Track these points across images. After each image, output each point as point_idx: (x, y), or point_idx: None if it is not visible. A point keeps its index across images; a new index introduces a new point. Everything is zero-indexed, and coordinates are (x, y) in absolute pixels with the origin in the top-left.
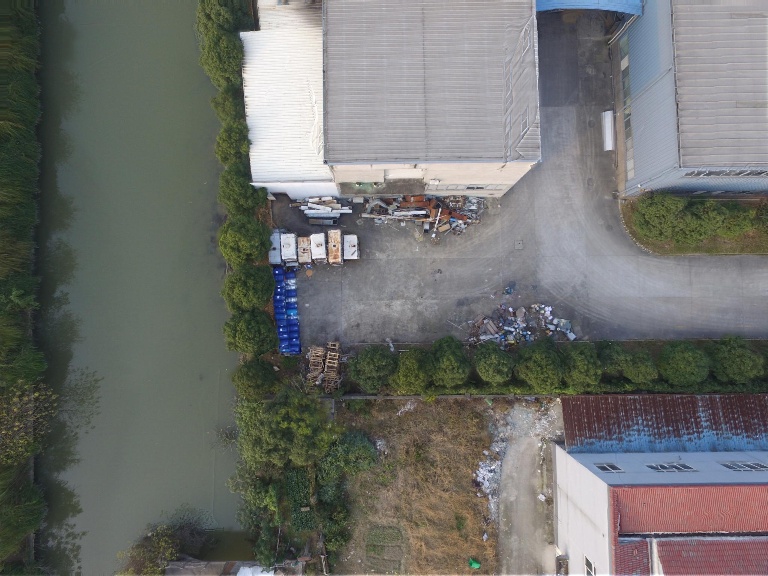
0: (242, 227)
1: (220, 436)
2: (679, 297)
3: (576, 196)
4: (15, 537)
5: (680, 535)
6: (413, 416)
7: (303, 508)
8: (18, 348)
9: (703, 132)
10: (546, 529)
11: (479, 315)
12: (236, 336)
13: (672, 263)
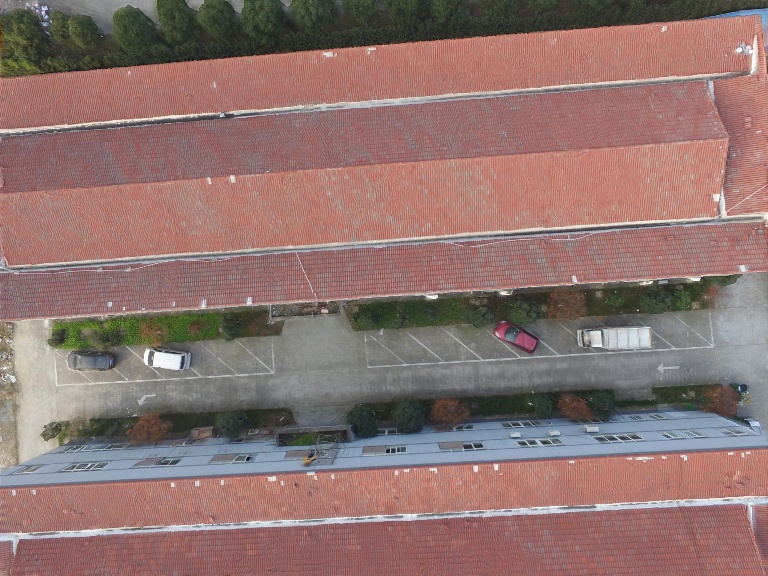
0: None
1: None
2: None
3: None
4: None
5: (29, 133)
6: None
7: None
8: None
9: None
10: None
11: None
12: None
13: None
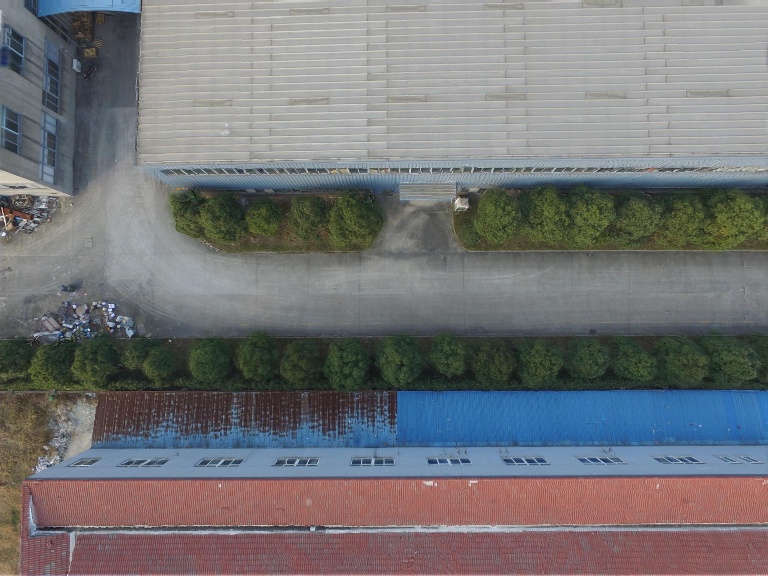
0: None
1: None
2: (244, 295)
3: (148, 195)
4: None
5: (106, 529)
6: None
7: None
8: None
9: (160, 131)
10: None
11: (44, 312)
12: None
13: (239, 261)
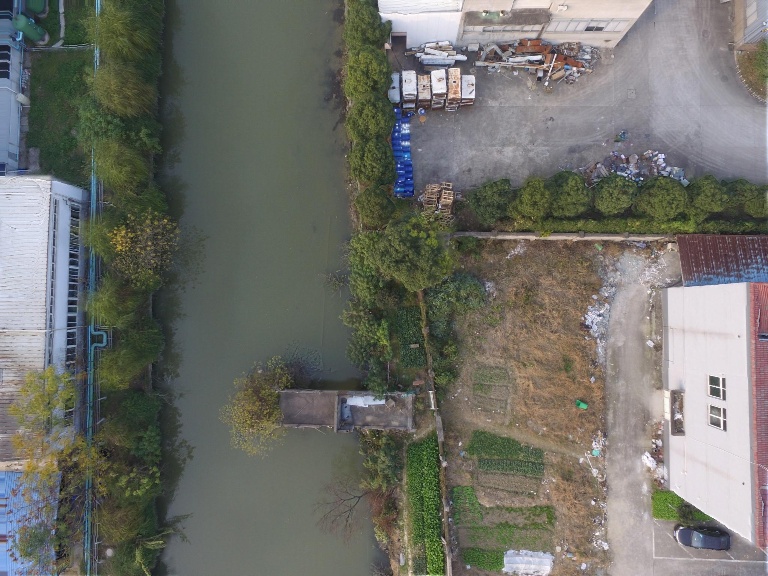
0: (372, 51)
1: (329, 280)
2: None
3: (691, 47)
4: (140, 358)
5: None
6: (522, 260)
7: (413, 344)
8: (146, 181)
9: None
10: (654, 375)
11: (591, 162)
12: (364, 156)
13: None
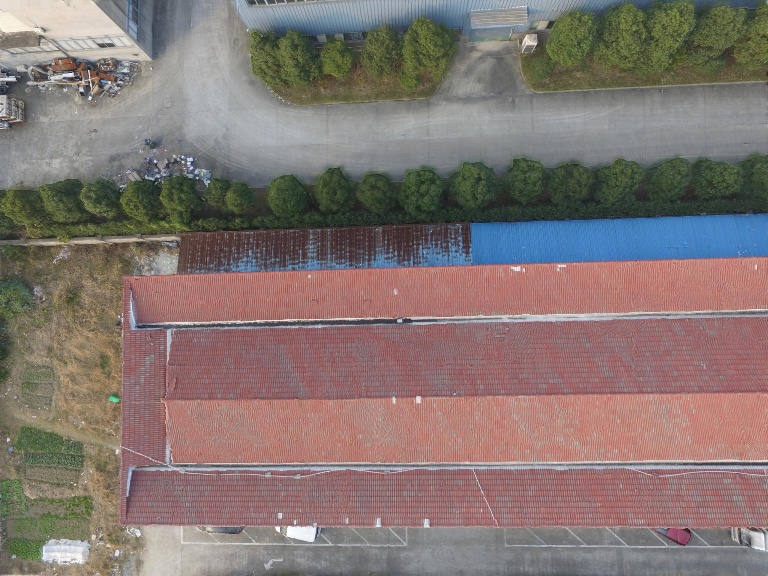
0: None
1: None
2: (315, 145)
3: (222, 55)
4: None
5: (200, 326)
6: (67, 264)
7: None
8: None
9: None
10: None
11: (127, 169)
12: None
13: (310, 113)
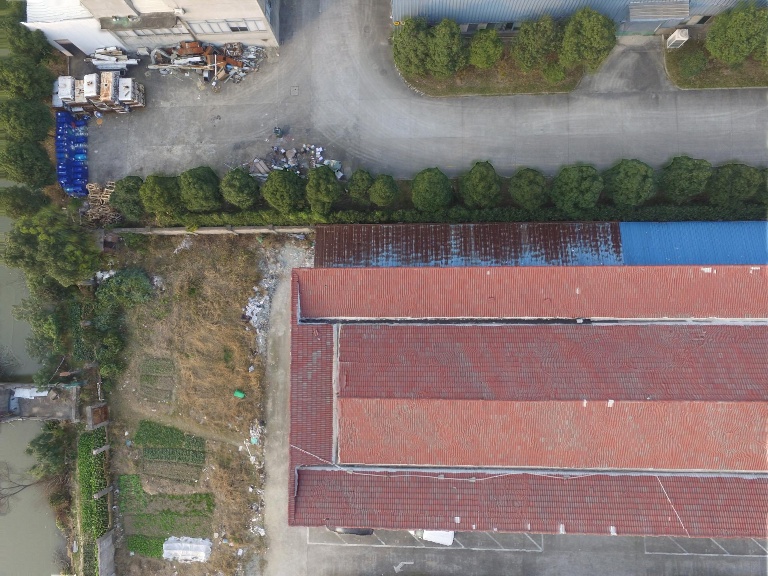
0: (7, 59)
1: (22, 278)
2: (450, 137)
3: (352, 43)
4: None
5: (367, 322)
6: (189, 254)
7: None
8: None
9: None
10: None
11: (253, 157)
12: None
13: (444, 104)
